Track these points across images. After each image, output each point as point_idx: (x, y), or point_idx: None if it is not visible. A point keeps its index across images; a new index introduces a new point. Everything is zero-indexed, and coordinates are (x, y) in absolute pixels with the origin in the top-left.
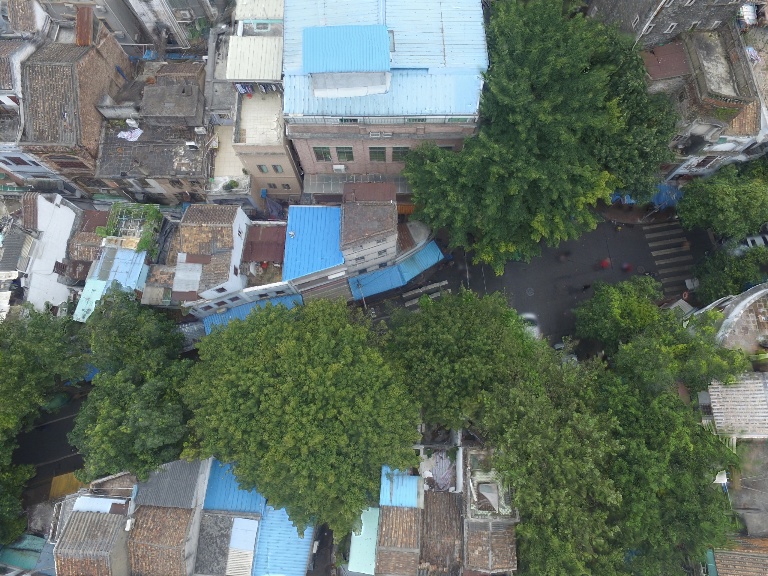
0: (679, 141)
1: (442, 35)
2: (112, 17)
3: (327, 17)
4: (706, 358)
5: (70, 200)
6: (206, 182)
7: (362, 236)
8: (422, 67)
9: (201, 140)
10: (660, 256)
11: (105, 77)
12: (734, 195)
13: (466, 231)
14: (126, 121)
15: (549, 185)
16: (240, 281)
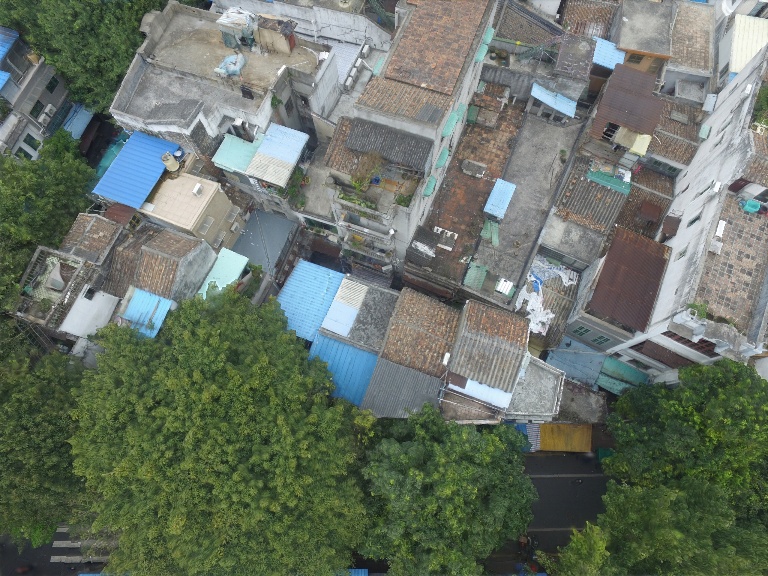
0: None
1: None
2: None
3: None
4: None
5: None
6: None
7: None
8: None
9: None
10: None
11: None
12: None
13: None
14: None
15: None
16: None
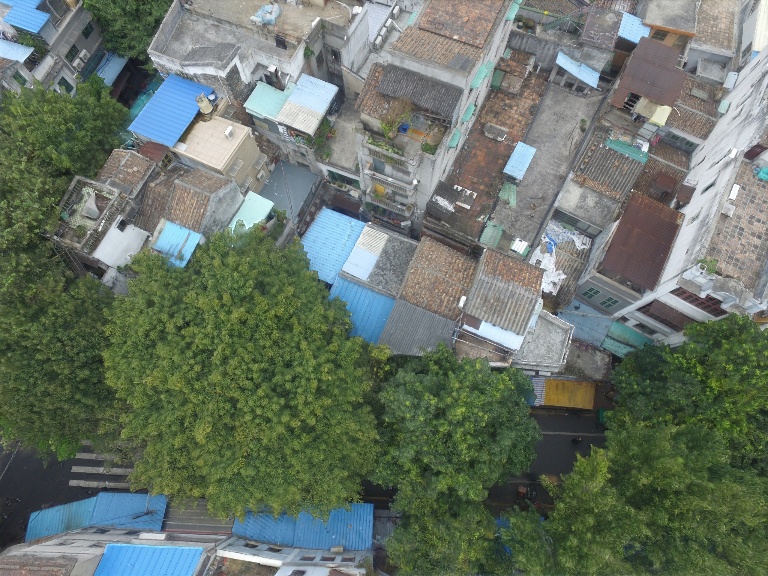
0: None
1: None
2: None
3: None
4: None
5: None
6: None
7: (31, 572)
8: None
9: None
10: None
11: None
12: None
13: None
14: None
15: None
16: None
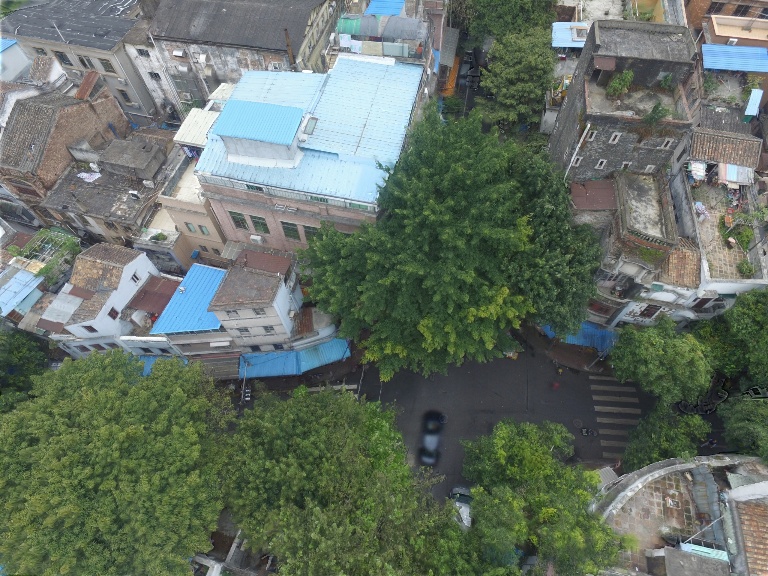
0: (616, 282)
1: (363, 129)
2: (131, 90)
3: (266, 100)
4: (562, 529)
5: (27, 227)
6: (137, 230)
7: (235, 301)
8: (332, 151)
9: (147, 192)
10: (604, 413)
11: (91, 128)
12: (661, 347)
13: (361, 326)
14: (89, 164)
15: (433, 286)
16: (119, 326)
